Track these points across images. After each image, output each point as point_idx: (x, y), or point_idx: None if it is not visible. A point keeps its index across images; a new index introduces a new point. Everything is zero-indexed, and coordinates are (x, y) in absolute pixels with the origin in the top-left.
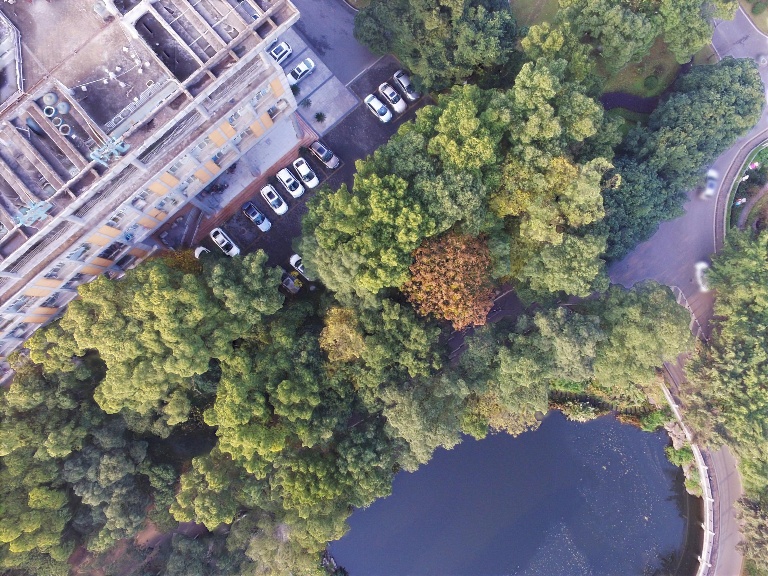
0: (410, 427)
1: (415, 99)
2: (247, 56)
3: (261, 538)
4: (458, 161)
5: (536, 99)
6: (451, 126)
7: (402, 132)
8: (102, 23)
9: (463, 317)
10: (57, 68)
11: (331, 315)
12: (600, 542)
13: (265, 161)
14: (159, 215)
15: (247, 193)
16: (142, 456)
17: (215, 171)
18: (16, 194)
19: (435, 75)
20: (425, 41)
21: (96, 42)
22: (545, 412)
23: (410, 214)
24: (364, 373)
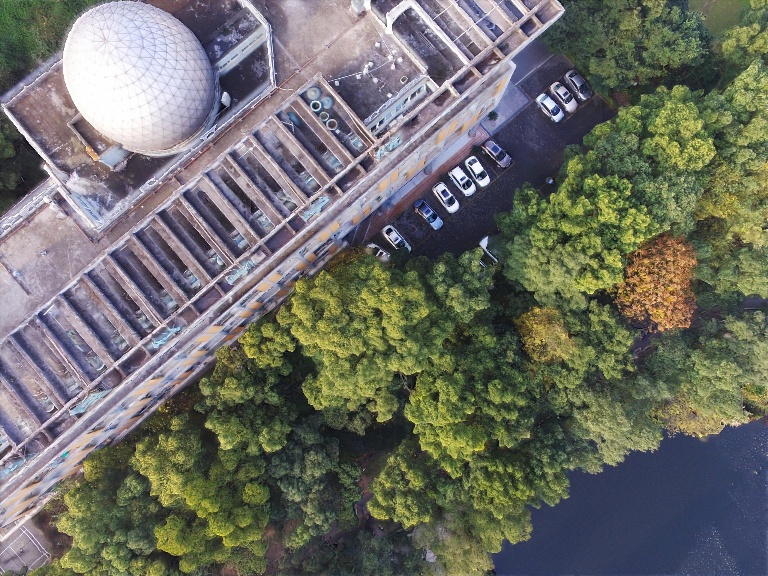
0: (615, 429)
1: (586, 99)
2: (513, 53)
3: (455, 537)
4: (681, 162)
5: (759, 101)
6: (672, 127)
7: (601, 132)
8: (353, 18)
9: (669, 319)
10: (309, 62)
11: (532, 315)
12: (752, 547)
13: (436, 159)
14: (366, 211)
15: (418, 191)
16: (337, 453)
17: (419, 168)
18: (274, 188)
19: (622, 75)
20: (613, 41)
21: (347, 37)
22: (740, 416)
23: (639, 215)
24: (565, 374)
